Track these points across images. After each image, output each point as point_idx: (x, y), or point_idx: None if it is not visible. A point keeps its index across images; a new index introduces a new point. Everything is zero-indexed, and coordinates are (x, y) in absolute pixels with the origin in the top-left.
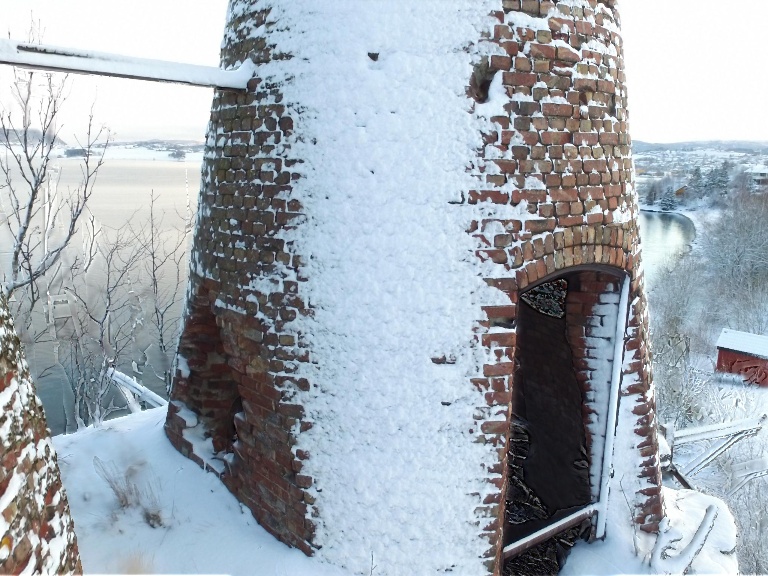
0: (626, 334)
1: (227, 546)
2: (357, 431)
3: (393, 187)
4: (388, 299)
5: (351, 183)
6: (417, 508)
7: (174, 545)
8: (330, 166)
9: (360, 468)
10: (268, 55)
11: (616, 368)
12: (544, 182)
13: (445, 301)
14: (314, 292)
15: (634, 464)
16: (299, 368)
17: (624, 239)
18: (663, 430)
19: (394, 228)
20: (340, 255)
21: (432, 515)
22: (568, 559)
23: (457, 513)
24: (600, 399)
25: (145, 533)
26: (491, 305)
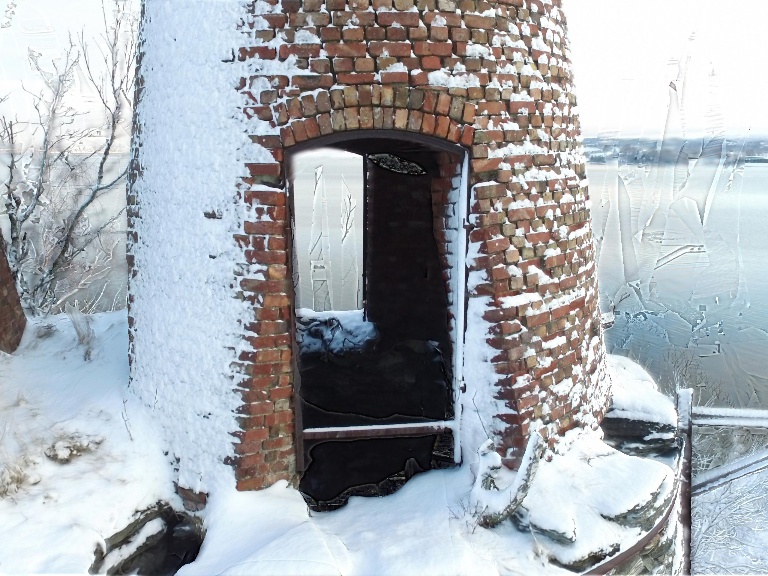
0: (467, 222)
1: (104, 376)
2: (157, 278)
3: (184, 51)
4: (177, 156)
5: (162, 52)
6: (186, 353)
7: (81, 371)
8: (154, 40)
9: (155, 311)
10: None
11: (459, 262)
12: (319, 36)
13: (215, 157)
14: (144, 155)
15: (488, 381)
16: (135, 223)
17: (453, 107)
18: (675, 396)
19: (184, 90)
20: (156, 119)
21: (196, 361)
22: (416, 475)
23: (215, 363)
24: (455, 301)
25: (77, 362)
26: (255, 162)
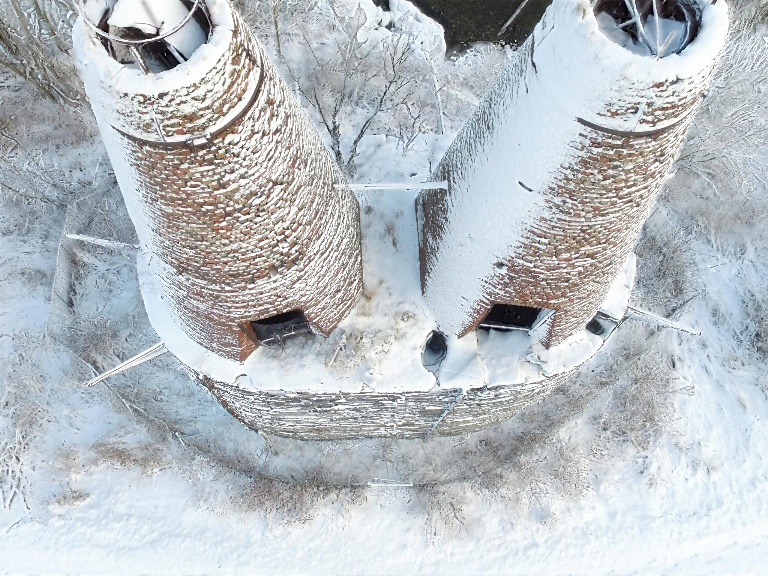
0: None
1: (408, 271)
2: None
3: None
4: (455, 279)
5: None
6: None
7: (396, 259)
8: None
9: None
10: (450, 194)
11: None
12: (514, 290)
13: (469, 291)
14: None
15: None
16: None
17: None
18: None
19: None
20: (447, 260)
21: None
22: (514, 331)
23: (457, 320)
24: None
25: (391, 247)
26: None
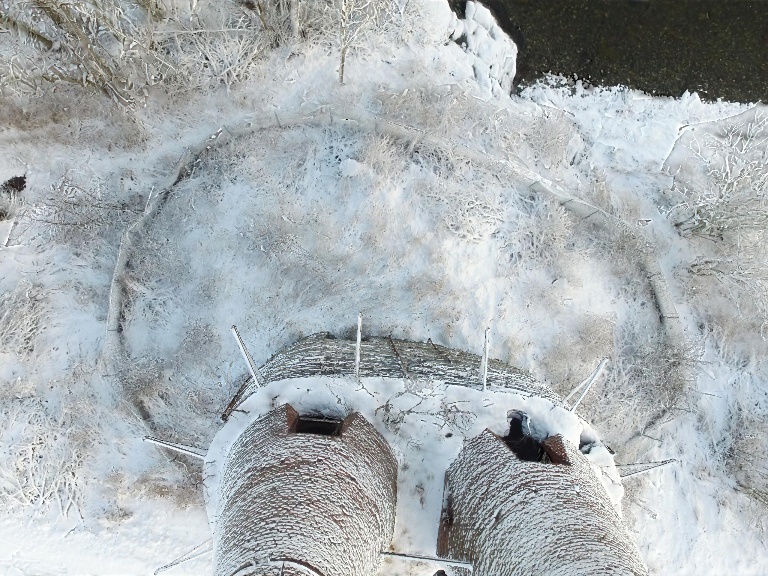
0: None
1: (428, 528)
2: None
3: None
4: None
5: None
6: None
7: (421, 515)
8: None
9: None
10: None
11: None
12: None
13: None
14: None
15: None
16: None
17: None
18: None
19: None
20: None
21: None
22: None
23: None
24: None
25: (418, 503)
26: None
